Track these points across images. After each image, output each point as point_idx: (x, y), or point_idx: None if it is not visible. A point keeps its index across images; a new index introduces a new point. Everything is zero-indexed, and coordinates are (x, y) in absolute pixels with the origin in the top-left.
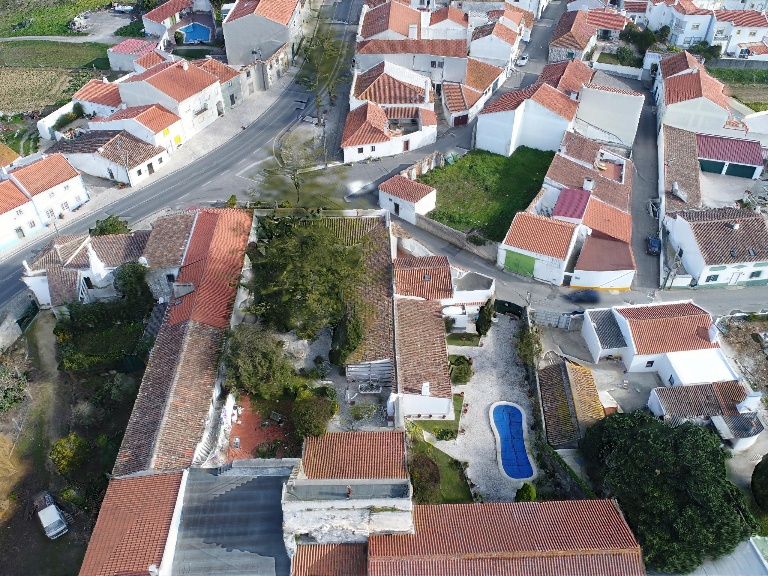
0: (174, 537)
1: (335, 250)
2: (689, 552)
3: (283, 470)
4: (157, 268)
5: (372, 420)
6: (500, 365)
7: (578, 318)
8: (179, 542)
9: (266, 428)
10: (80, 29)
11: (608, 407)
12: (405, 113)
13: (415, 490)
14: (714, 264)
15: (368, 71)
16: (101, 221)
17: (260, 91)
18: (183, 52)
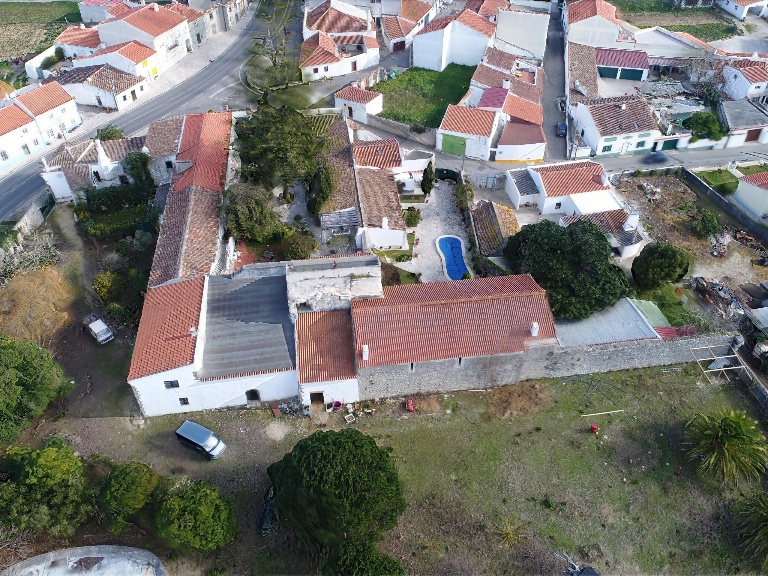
0: (204, 316)
1: (306, 125)
2: (583, 303)
3: (282, 270)
4: (158, 156)
5: (345, 253)
6: (442, 213)
7: (502, 177)
8: (208, 321)
9: None
10: None
11: None
12: (351, 40)
13: (382, 284)
14: (607, 135)
15: (317, 8)
16: (101, 130)
17: (222, 32)
18: None
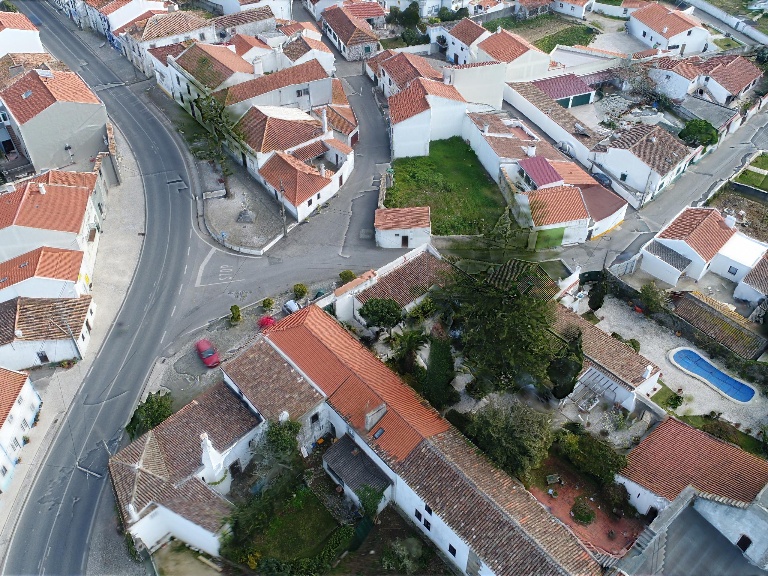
0: None
1: None
2: None
3: None
4: (301, 415)
5: (616, 428)
6: (632, 326)
7: (640, 258)
8: None
9: (558, 495)
10: None
11: (734, 311)
12: (314, 150)
13: None
14: (665, 174)
15: (240, 122)
16: (143, 409)
17: (113, 188)
18: None
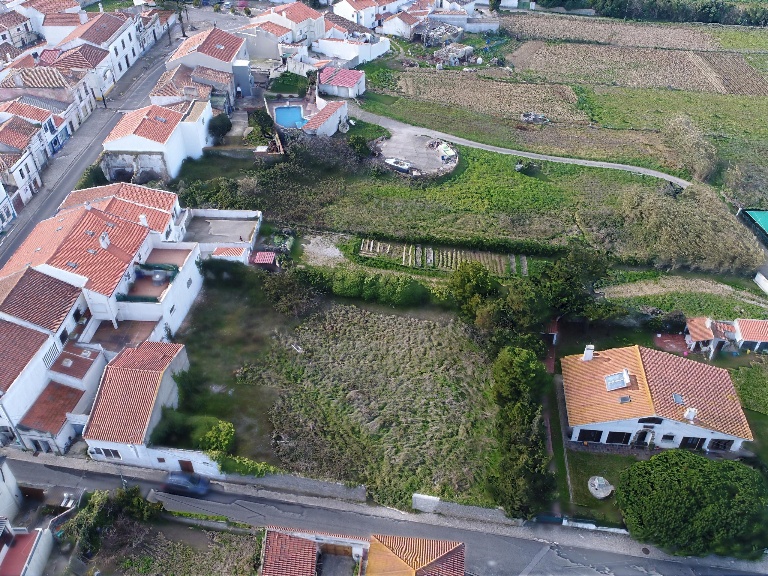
0: None
1: None
2: None
3: None
4: None
5: None
6: None
7: None
8: None
9: None
10: (437, 141)
11: None
12: None
13: None
14: None
15: None
16: None
17: None
18: None
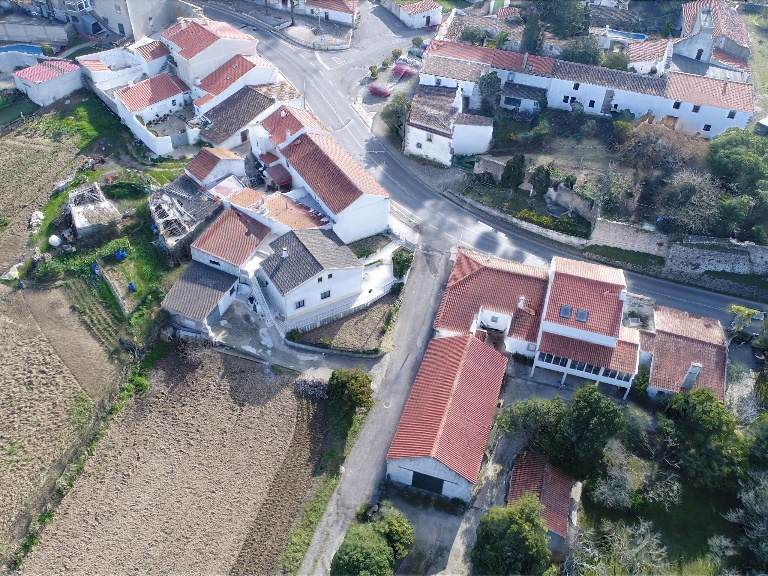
0: None
1: None
2: None
3: None
4: None
5: None
6: None
7: None
8: None
9: None
10: None
11: None
12: None
13: None
14: None
15: None
16: None
17: None
18: (72, 59)
